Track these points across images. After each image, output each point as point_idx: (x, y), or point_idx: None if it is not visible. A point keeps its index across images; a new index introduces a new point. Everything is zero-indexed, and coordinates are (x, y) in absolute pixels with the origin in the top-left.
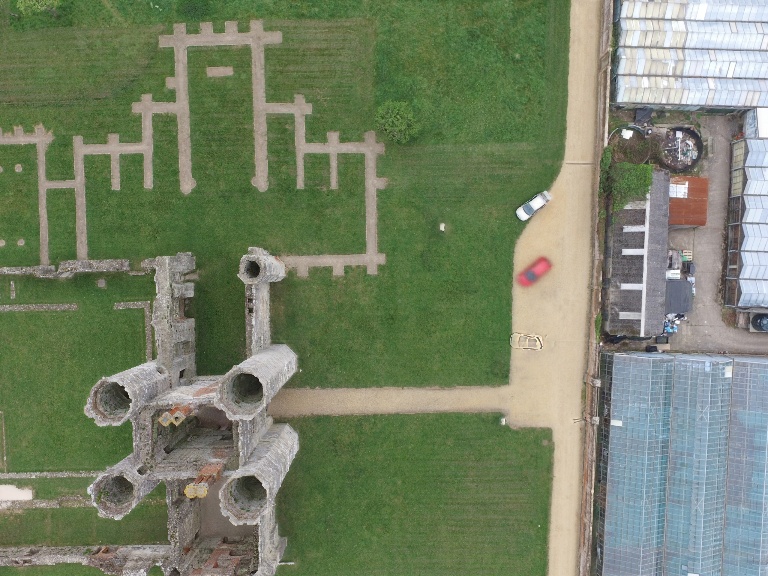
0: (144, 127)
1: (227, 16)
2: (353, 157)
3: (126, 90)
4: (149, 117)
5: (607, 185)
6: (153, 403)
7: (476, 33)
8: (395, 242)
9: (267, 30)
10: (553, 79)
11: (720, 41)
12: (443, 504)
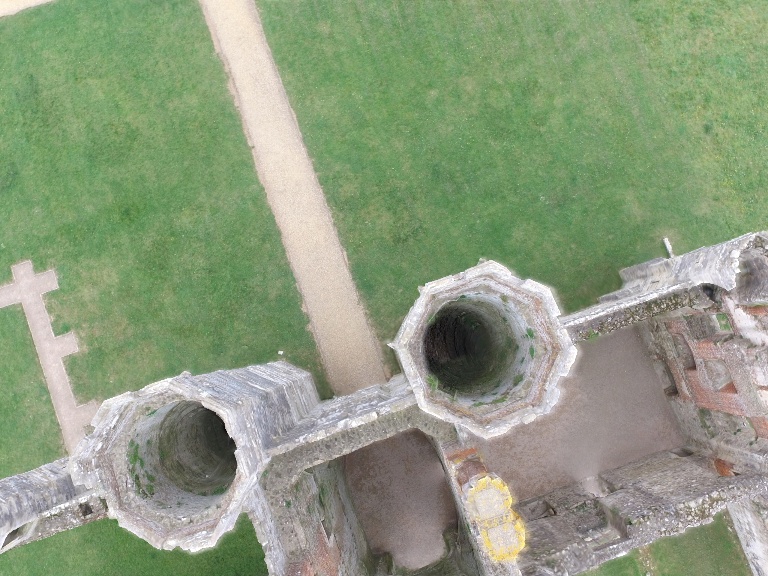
0: None
1: None
2: None
3: None
4: None
5: None
6: None
7: None
8: None
9: None
10: None
11: None
12: (446, 1)
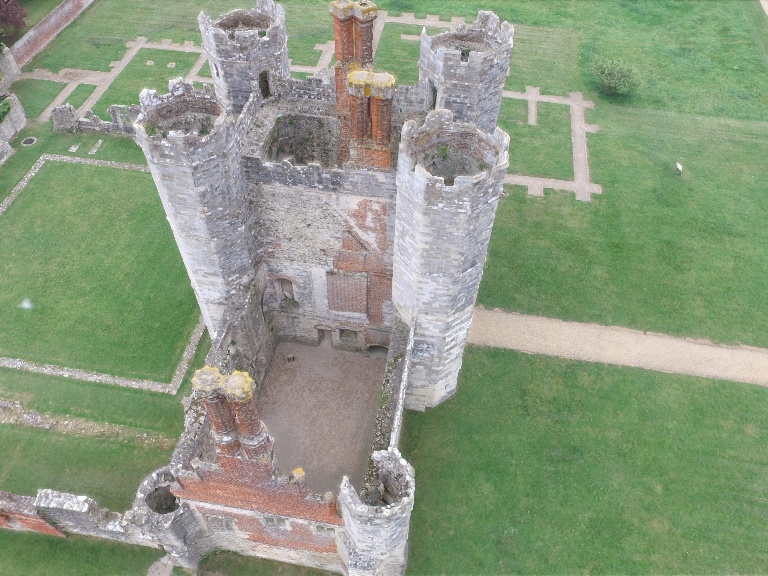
0: (322, 58)
1: (430, 12)
2: (556, 105)
3: (314, 36)
4: (330, 53)
5: None
6: None
7: (687, 47)
8: (614, 175)
9: (468, 22)
10: None
11: None
12: (764, 552)
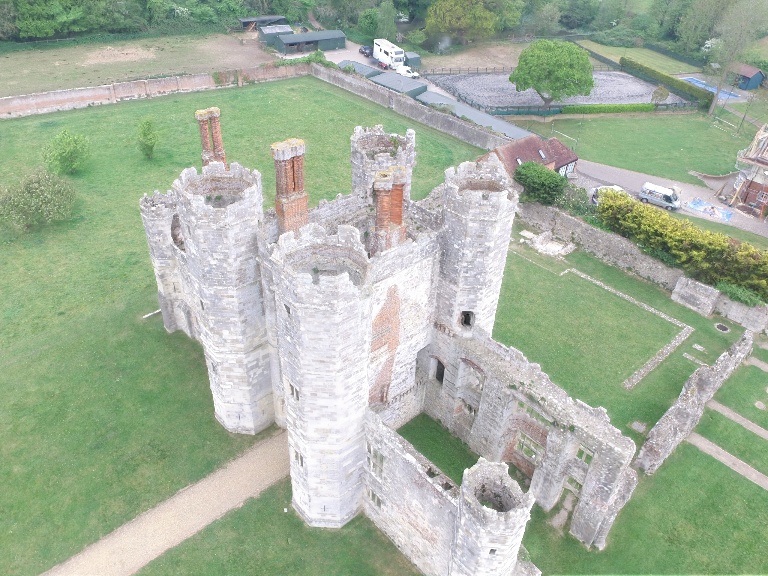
0: None
1: None
2: None
3: None
4: None
5: None
6: (435, 234)
7: None
8: None
9: None
10: None
11: None
12: None
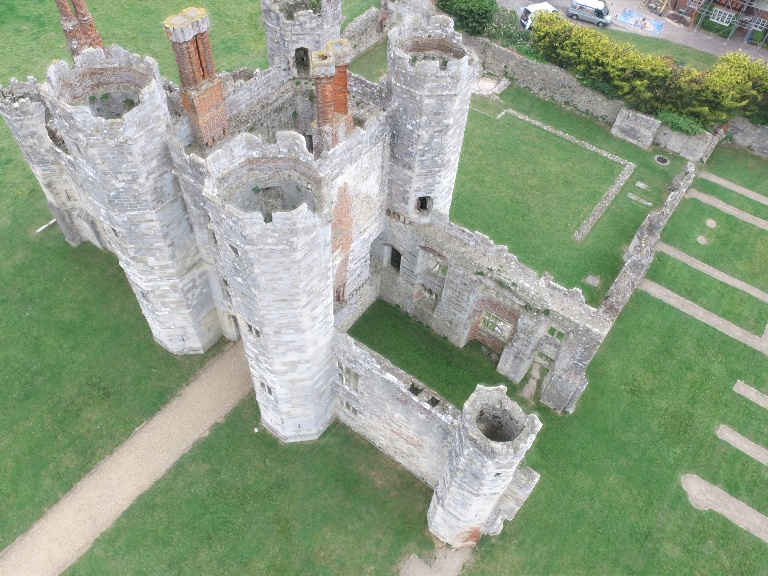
0: None
1: None
2: None
3: None
4: None
5: None
6: (384, 115)
7: None
8: None
9: None
10: None
11: None
12: None
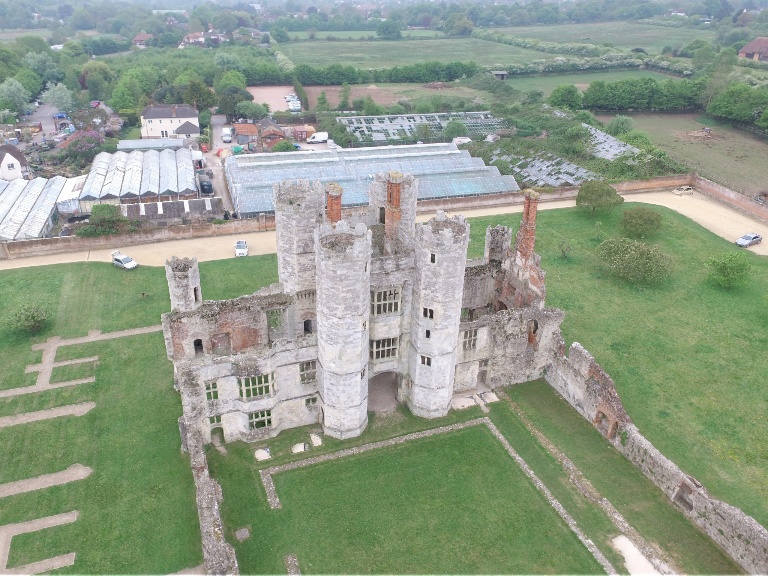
0: None
1: None
2: (61, 352)
3: None
4: None
5: (108, 225)
6: None
7: None
8: None
9: None
10: (7, 274)
11: (0, 213)
12: None
